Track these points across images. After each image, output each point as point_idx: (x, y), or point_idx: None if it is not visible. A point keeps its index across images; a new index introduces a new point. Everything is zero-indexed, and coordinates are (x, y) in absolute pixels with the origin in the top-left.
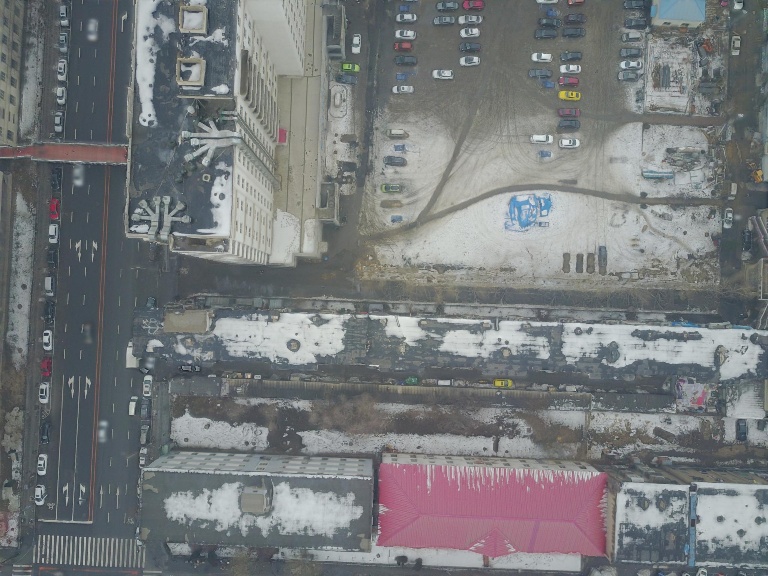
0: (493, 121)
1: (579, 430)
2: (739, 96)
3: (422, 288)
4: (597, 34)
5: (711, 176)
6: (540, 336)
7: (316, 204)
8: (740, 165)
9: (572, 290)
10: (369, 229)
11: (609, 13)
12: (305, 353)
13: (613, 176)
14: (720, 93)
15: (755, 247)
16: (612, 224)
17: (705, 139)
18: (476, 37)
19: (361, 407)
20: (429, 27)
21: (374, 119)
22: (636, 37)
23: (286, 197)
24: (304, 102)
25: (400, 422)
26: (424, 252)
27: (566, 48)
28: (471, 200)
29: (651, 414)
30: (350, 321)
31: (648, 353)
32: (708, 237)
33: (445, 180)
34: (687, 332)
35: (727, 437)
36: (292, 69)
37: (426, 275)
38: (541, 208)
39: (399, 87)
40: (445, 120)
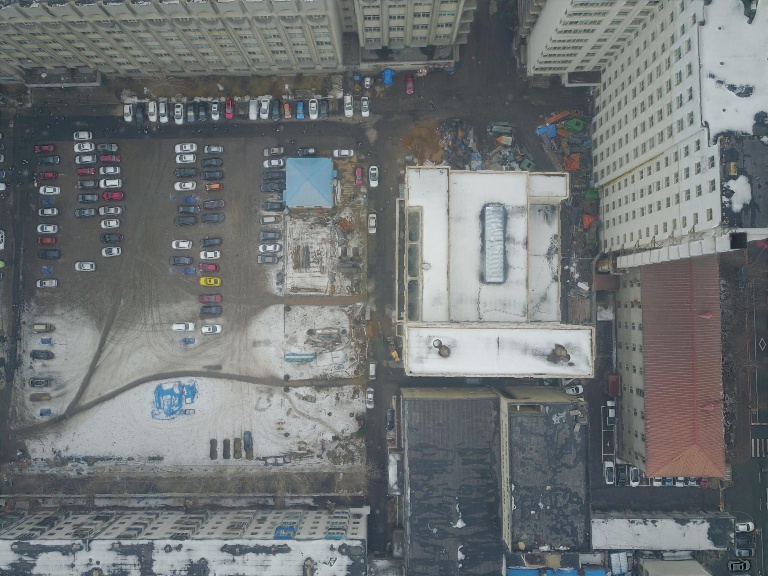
0: (137, 310)
1: None
2: (379, 273)
3: (73, 480)
4: (236, 218)
5: (353, 356)
6: (131, 555)
7: None
8: (382, 343)
9: (220, 476)
10: (19, 423)
11: (248, 196)
12: None
13: (257, 360)
14: (359, 272)
15: None
16: (257, 408)
17: (346, 319)
18: (117, 227)
19: None
20: (72, 219)
21: (21, 313)
22: (271, 221)
23: None
24: None
25: None
26: (74, 444)
27: (207, 233)
28: (118, 390)
29: None
30: None
31: (237, 568)
32: (353, 417)
33: (92, 371)
34: (276, 545)
35: None
36: None
37: (75, 468)
38: (185, 396)
39: (41, 282)
40: (90, 311)
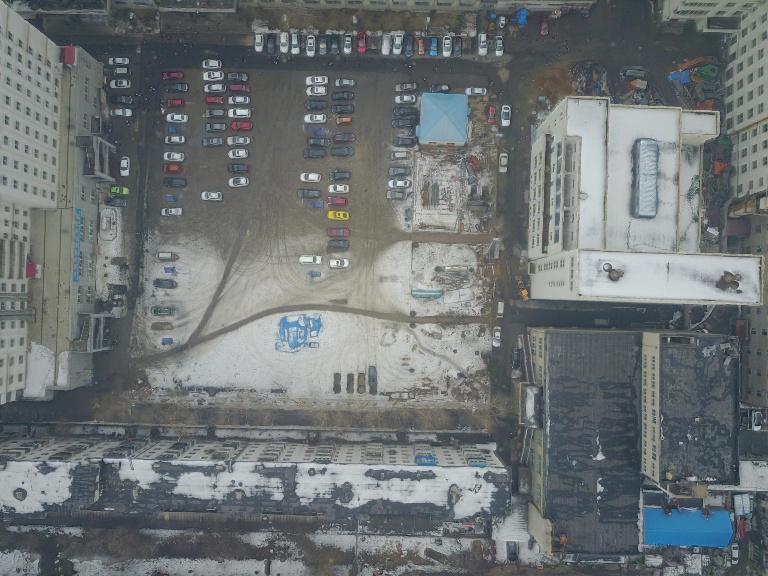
0: (263, 242)
1: (350, 552)
2: (508, 213)
3: (193, 411)
4: (366, 153)
5: (480, 294)
6: (274, 477)
7: (68, 337)
8: (509, 283)
9: (343, 410)
10: (140, 352)
11: (378, 131)
12: (32, 502)
13: (383, 295)
14: (488, 211)
15: (523, 366)
16: (382, 343)
17: (474, 257)
18: (245, 158)
19: (111, 543)
20: (199, 148)
21: (144, 241)
22: (402, 156)
23: (40, 330)
24: (58, 234)
25: (171, 546)
26: (195, 374)
27: (335, 167)
28: (241, 321)
29: (418, 537)
30: (77, 468)
31: (382, 493)
32: (478, 355)
33: (215, 302)
34: (421, 471)
35: (498, 557)
36: (38, 205)
37: (196, 398)
38: (310, 329)
39: (167, 210)
40: (215, 241)
